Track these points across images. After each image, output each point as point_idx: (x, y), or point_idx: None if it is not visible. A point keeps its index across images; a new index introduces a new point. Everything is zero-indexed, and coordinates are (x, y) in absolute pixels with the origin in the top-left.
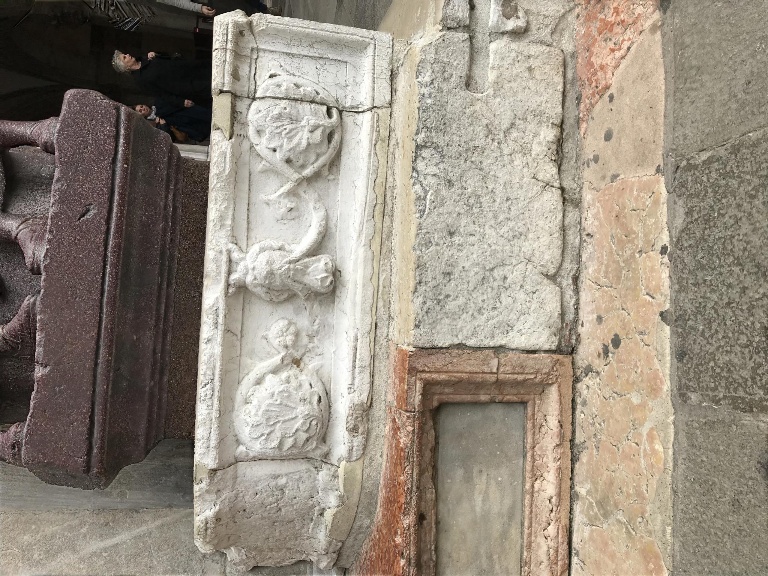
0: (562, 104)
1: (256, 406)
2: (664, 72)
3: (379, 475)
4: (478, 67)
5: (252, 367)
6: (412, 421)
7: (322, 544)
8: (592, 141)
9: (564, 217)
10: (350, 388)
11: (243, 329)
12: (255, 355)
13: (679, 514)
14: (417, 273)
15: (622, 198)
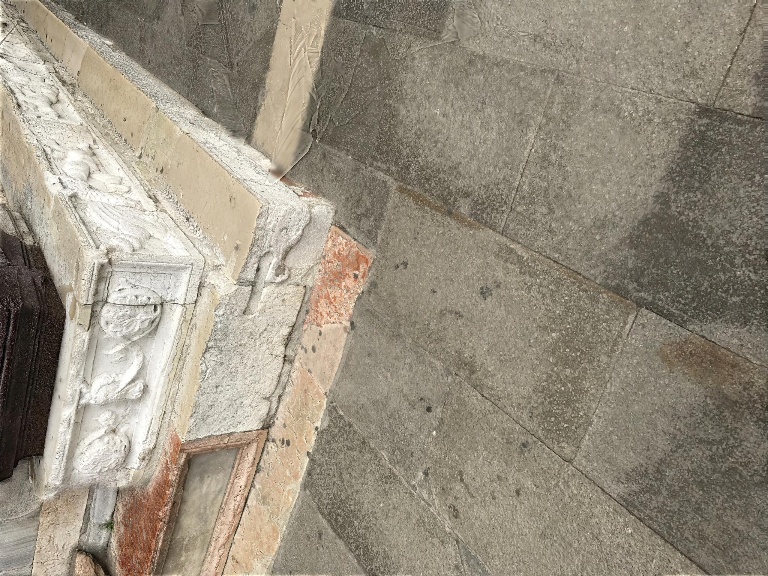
0: (297, 316)
1: (88, 457)
2: (342, 355)
3: (153, 473)
4: (253, 301)
5: (87, 436)
6: (177, 470)
7: (112, 486)
8: (307, 340)
9: (282, 370)
10: (144, 442)
11: (83, 418)
12: (89, 429)
13: (290, 523)
14: (194, 408)
15: (309, 386)
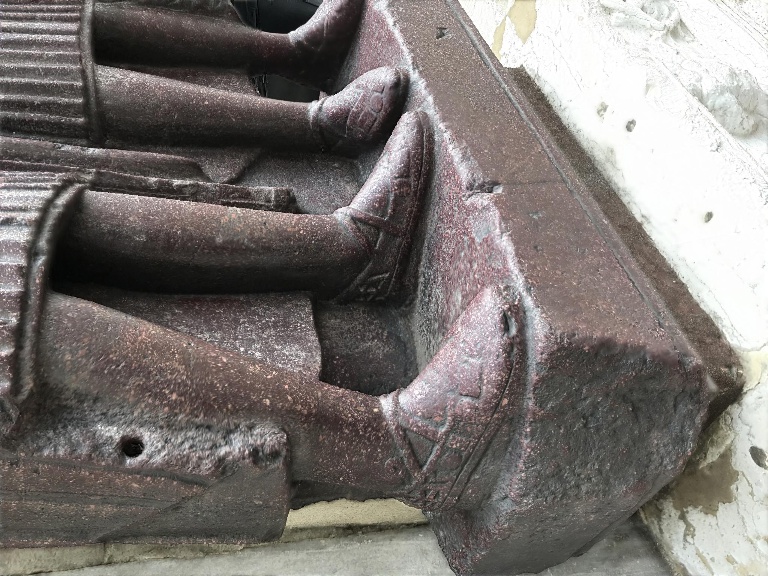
0: None
1: None
2: None
3: None
4: None
5: None
6: None
7: None
8: None
9: None
10: None
11: None
12: None
13: None
14: None
15: None
